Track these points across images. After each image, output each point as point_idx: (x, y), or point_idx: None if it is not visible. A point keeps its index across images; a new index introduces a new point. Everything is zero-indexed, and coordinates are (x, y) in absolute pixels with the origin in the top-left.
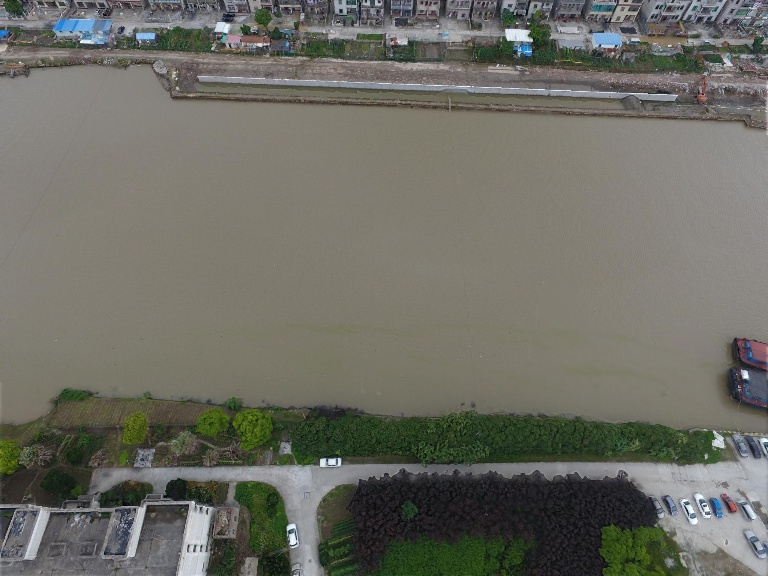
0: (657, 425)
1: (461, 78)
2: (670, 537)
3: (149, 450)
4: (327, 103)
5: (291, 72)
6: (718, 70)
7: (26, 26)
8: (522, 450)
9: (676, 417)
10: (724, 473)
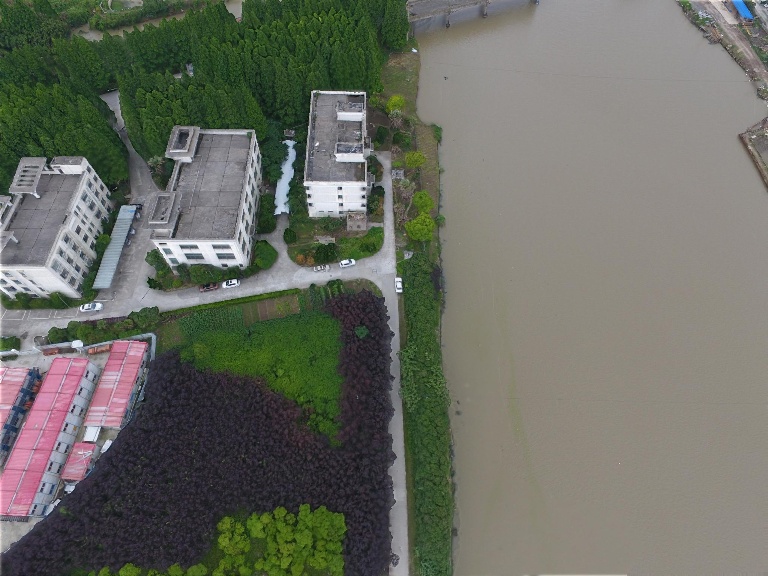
0: None
1: None
2: None
3: (403, 176)
4: None
5: None
6: None
7: (767, 26)
8: None
9: None
10: None
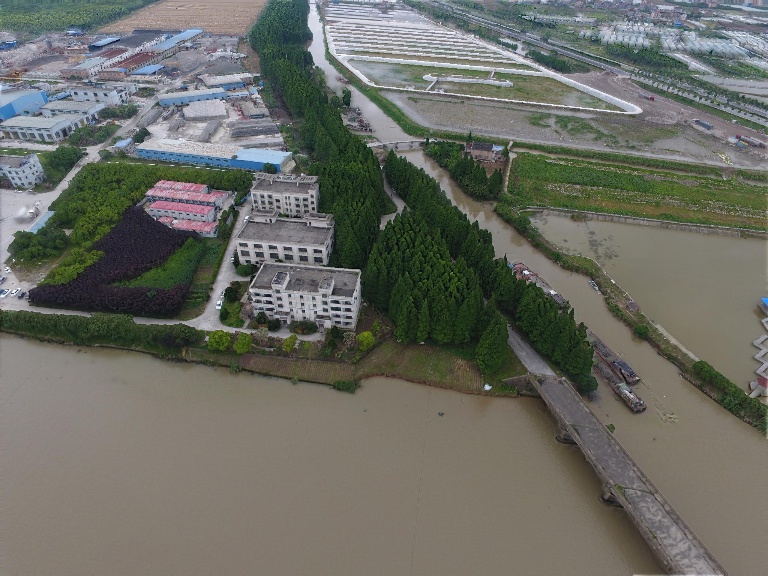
0: None
1: None
2: None
3: None
4: None
5: None
6: None
7: None
8: None
9: None
10: None
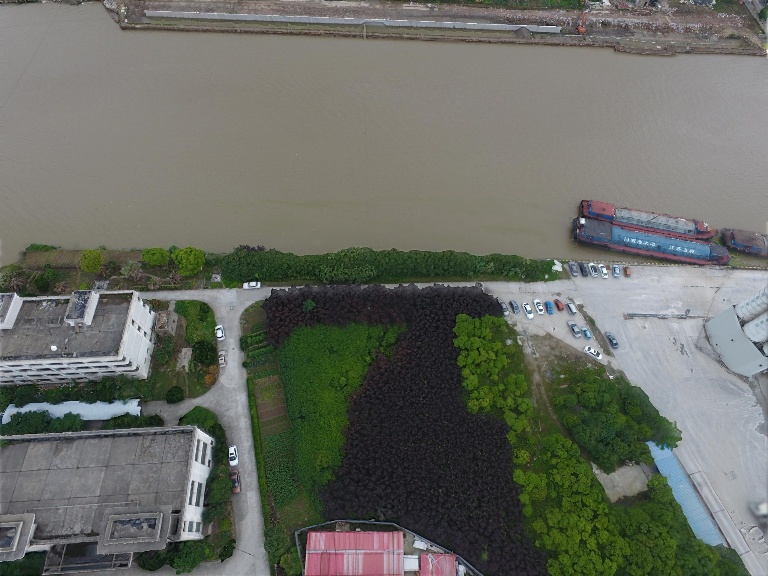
0: (510, 255)
1: (379, 13)
2: (512, 327)
3: (104, 282)
4: (260, 33)
5: (229, 8)
6: (598, 8)
7: None
8: (403, 273)
9: (530, 255)
10: (559, 287)
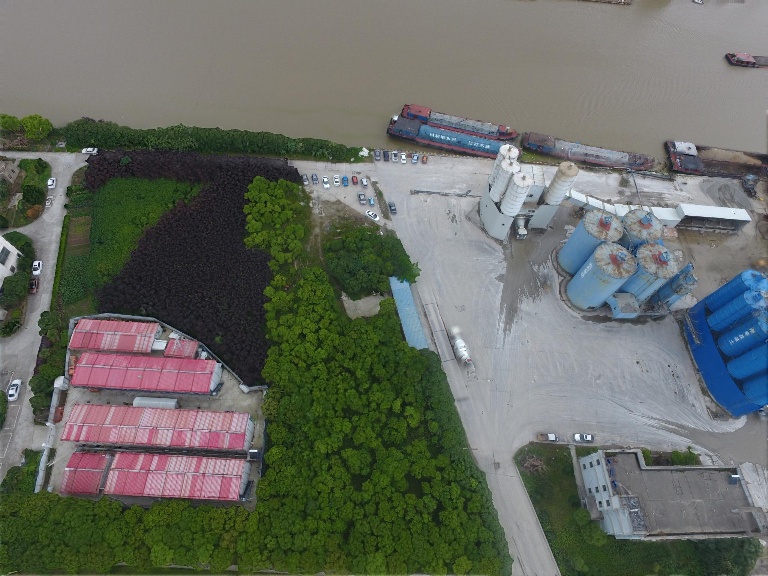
0: None
1: None
2: (308, 194)
3: None
4: None
5: None
6: None
7: None
8: (224, 148)
9: (348, 146)
10: (361, 168)
